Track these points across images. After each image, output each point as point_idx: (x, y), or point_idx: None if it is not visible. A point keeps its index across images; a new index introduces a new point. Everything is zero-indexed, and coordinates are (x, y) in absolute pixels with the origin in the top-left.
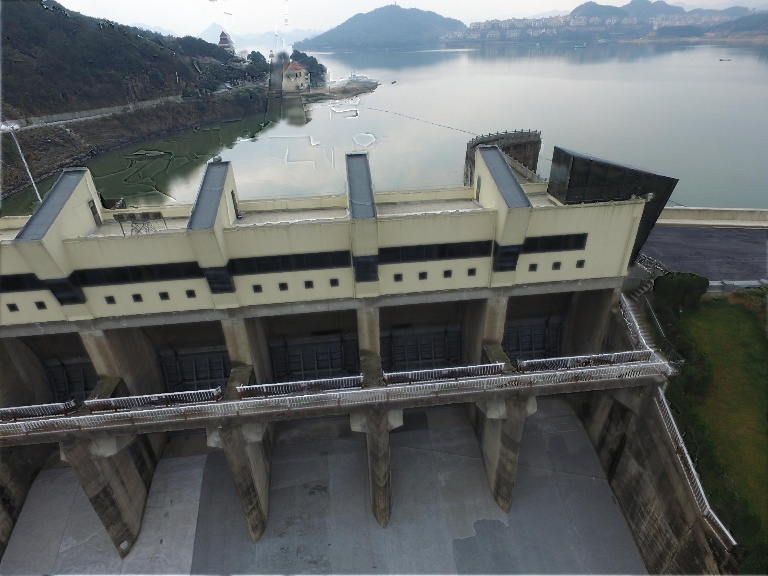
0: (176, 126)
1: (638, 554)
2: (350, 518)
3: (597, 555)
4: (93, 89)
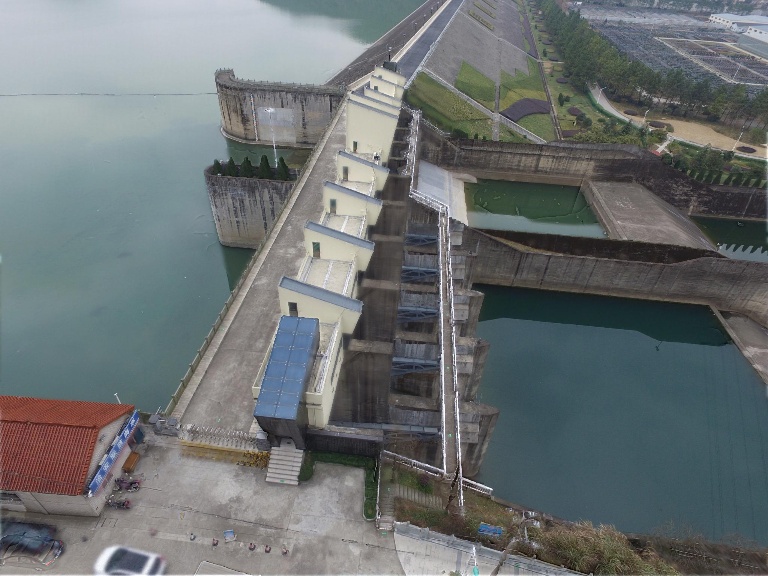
0: None
1: (431, 164)
2: None
3: (430, 168)
4: None
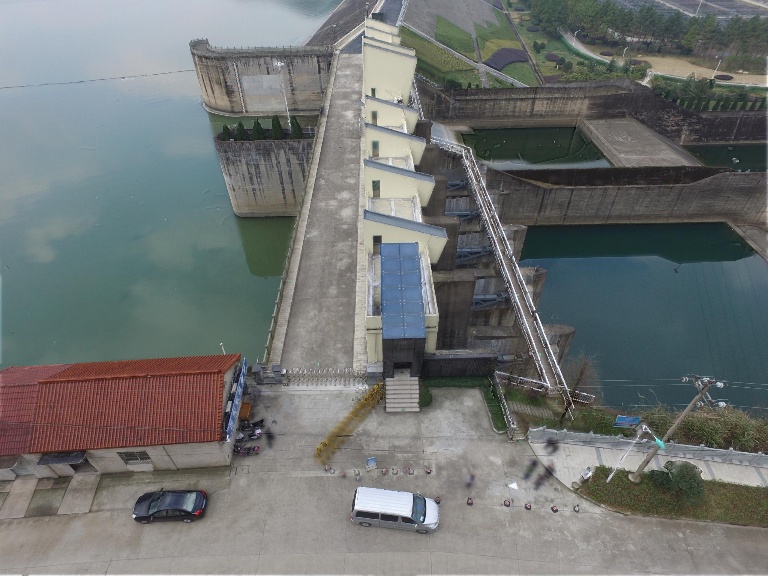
0: None
1: None
2: None
3: None
4: None
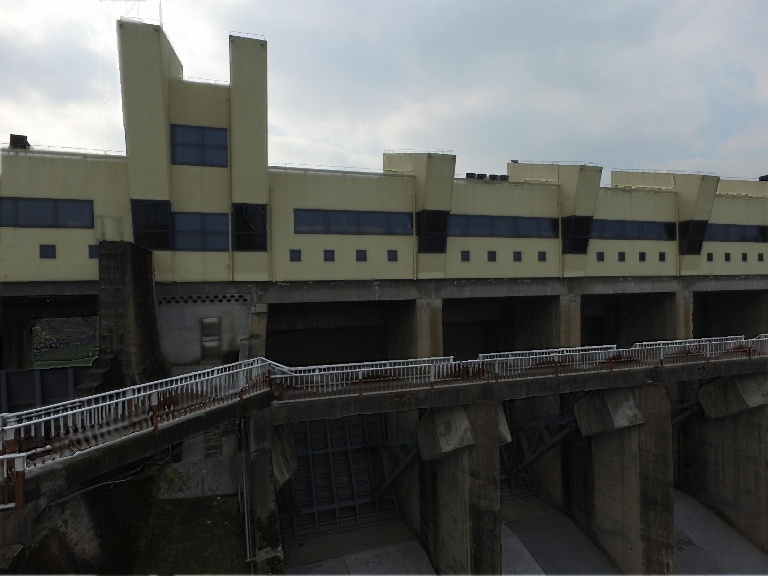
0: None
1: None
2: (756, 571)
3: None
4: None
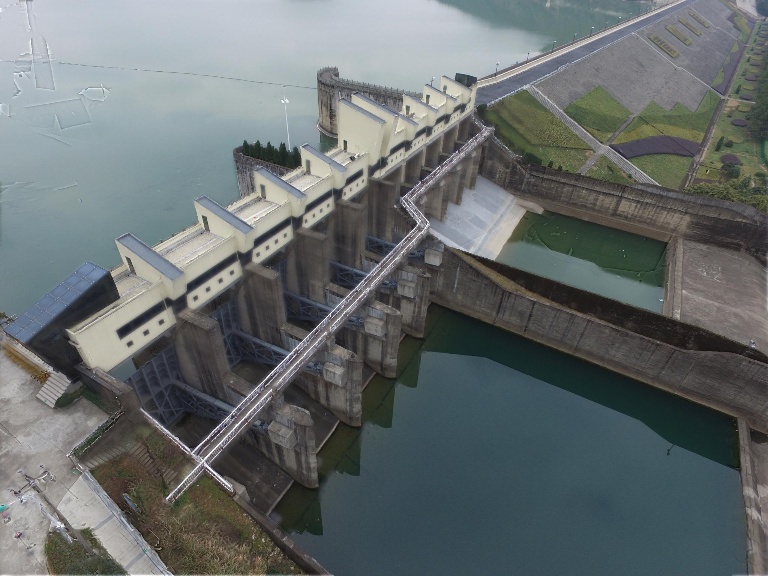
0: None
1: (497, 186)
2: (453, 208)
3: (493, 189)
4: None
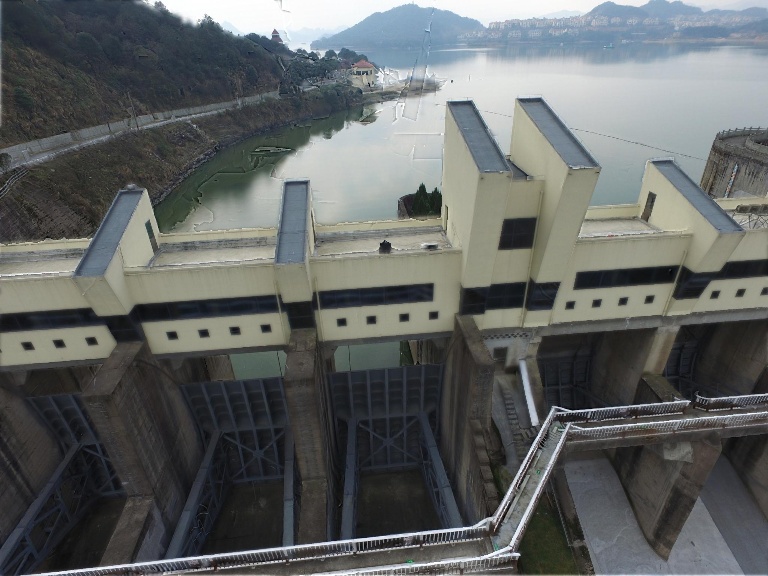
0: (276, 123)
1: None
2: None
3: None
4: (203, 85)
